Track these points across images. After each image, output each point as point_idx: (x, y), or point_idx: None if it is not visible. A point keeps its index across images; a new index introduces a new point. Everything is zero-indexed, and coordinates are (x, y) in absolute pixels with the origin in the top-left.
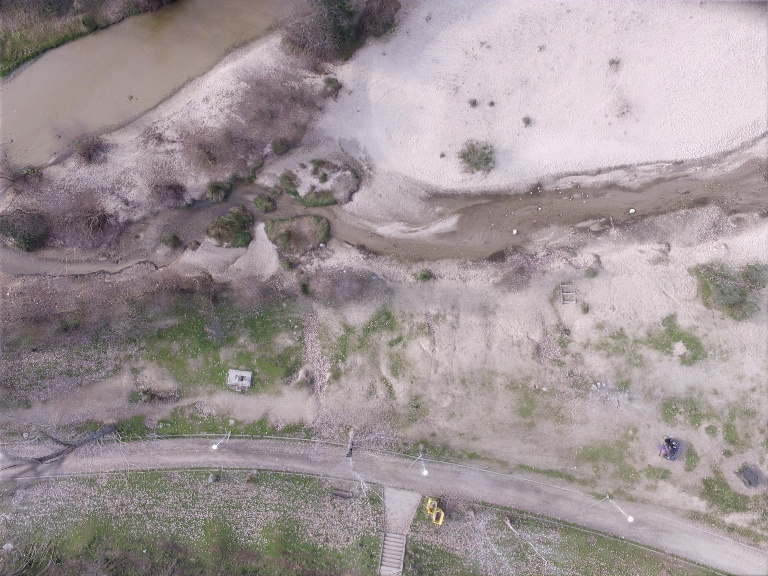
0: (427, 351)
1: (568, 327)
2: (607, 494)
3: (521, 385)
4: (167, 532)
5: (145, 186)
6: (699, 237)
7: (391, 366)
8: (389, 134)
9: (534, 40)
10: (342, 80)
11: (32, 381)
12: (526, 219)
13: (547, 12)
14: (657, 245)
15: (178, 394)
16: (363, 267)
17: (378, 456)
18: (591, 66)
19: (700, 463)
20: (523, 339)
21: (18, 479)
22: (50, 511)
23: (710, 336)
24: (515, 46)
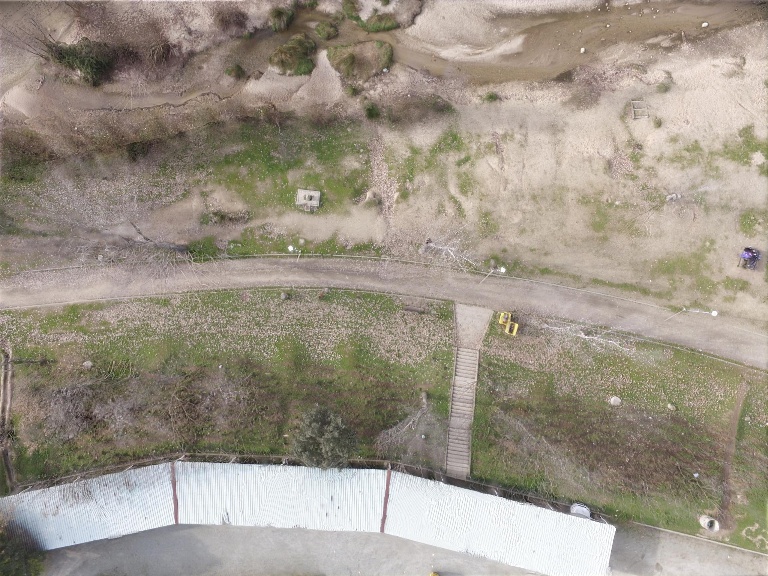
0: (496, 169)
1: (640, 142)
2: (684, 307)
3: (593, 199)
4: (241, 350)
5: (207, 15)
6: None
7: (459, 185)
8: None
9: None
10: None
11: (104, 207)
12: (594, 37)
13: None
14: (731, 59)
15: (248, 215)
16: (427, 90)
17: (449, 273)
18: None
19: None
20: (594, 155)
21: (94, 300)
22: (127, 330)
23: None
24: None
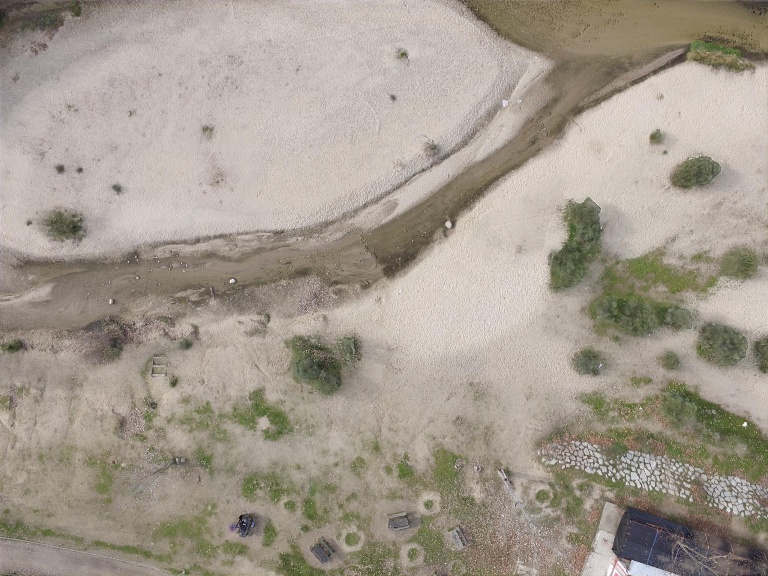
0: (6, 426)
1: (156, 400)
2: (183, 570)
3: (99, 461)
4: None
5: None
6: (300, 308)
7: None
8: None
9: (124, 104)
10: None
11: None
12: (124, 288)
13: (138, 75)
14: (257, 316)
15: None
16: None
17: None
18: (184, 133)
19: (278, 538)
20: (107, 413)
21: None
22: None
23: (297, 410)
24: (105, 110)
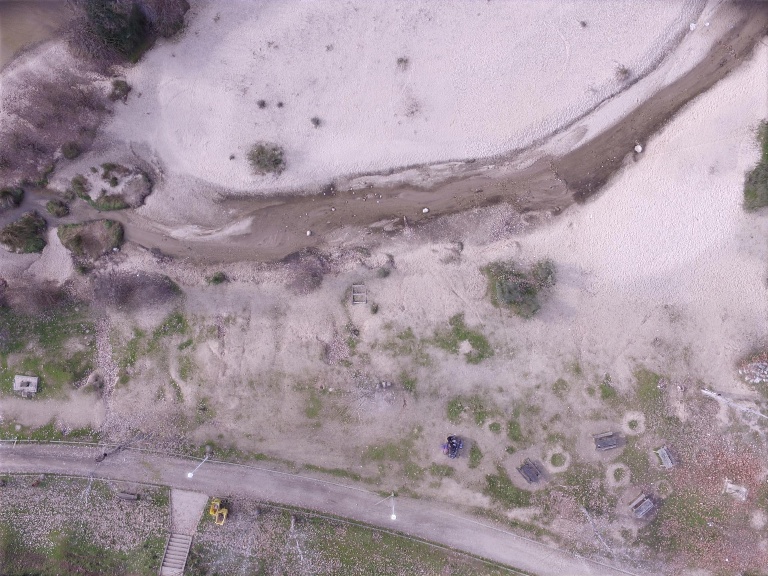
0: (216, 354)
1: (358, 327)
2: (392, 492)
3: (308, 386)
4: None
5: None
6: (492, 236)
7: (180, 369)
8: (180, 137)
9: (322, 39)
10: (131, 82)
11: None
12: (320, 220)
13: (334, 11)
14: (450, 244)
15: None
16: (156, 271)
17: (165, 458)
18: (379, 65)
19: (484, 460)
20: (312, 340)
21: None
22: None
23: (497, 334)
24: (303, 46)
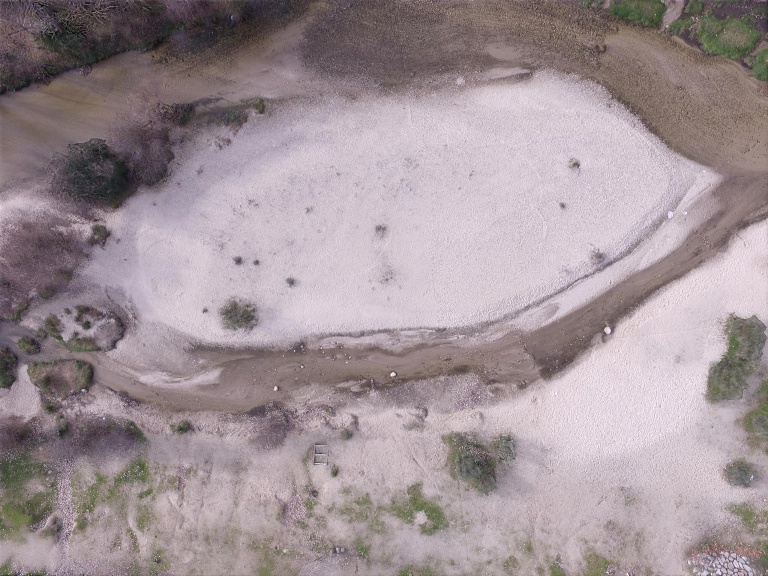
0: (174, 506)
1: (317, 488)
2: None
3: (262, 545)
4: None
5: None
6: (457, 404)
7: (138, 518)
8: (155, 285)
9: (302, 201)
10: (111, 228)
11: None
12: (288, 376)
13: (317, 174)
14: (415, 410)
15: None
16: (122, 415)
17: None
18: (358, 231)
19: None
20: (270, 499)
21: None
22: None
23: (453, 507)
24: (283, 206)
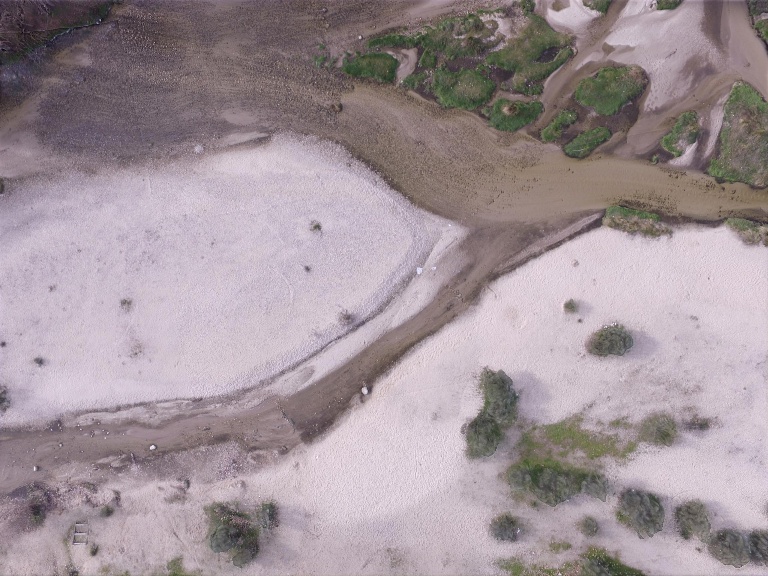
0: None
1: (77, 569)
2: None
3: None
4: None
5: None
6: (218, 474)
7: None
8: None
9: (45, 280)
10: None
11: None
12: (48, 455)
13: (58, 252)
14: (176, 482)
15: None
16: None
17: None
18: (103, 306)
19: None
20: None
21: None
22: None
23: None
24: (26, 286)
